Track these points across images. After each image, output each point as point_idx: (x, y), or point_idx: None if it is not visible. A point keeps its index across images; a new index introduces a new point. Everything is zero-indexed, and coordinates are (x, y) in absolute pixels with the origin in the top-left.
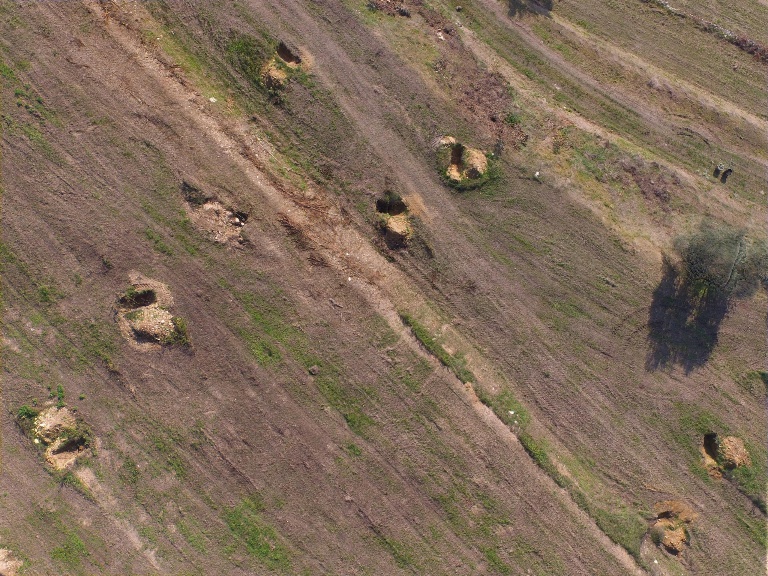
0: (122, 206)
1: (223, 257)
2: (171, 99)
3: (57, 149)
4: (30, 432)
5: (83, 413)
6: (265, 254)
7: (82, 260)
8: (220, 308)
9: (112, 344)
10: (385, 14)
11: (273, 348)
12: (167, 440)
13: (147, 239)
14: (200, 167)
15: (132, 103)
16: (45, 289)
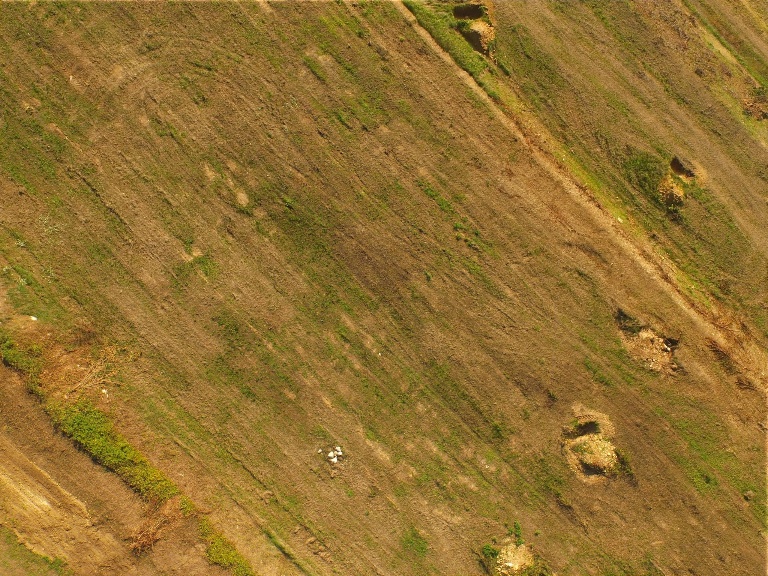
0: (561, 337)
1: (658, 385)
2: (599, 226)
3: (496, 282)
4: (494, 571)
5: (539, 549)
6: (697, 380)
7: (528, 394)
8: (658, 436)
9: (561, 478)
10: (754, 119)
11: (710, 475)
12: (619, 572)
13: (586, 370)
14: (630, 294)
15: (563, 232)
16: (498, 426)
